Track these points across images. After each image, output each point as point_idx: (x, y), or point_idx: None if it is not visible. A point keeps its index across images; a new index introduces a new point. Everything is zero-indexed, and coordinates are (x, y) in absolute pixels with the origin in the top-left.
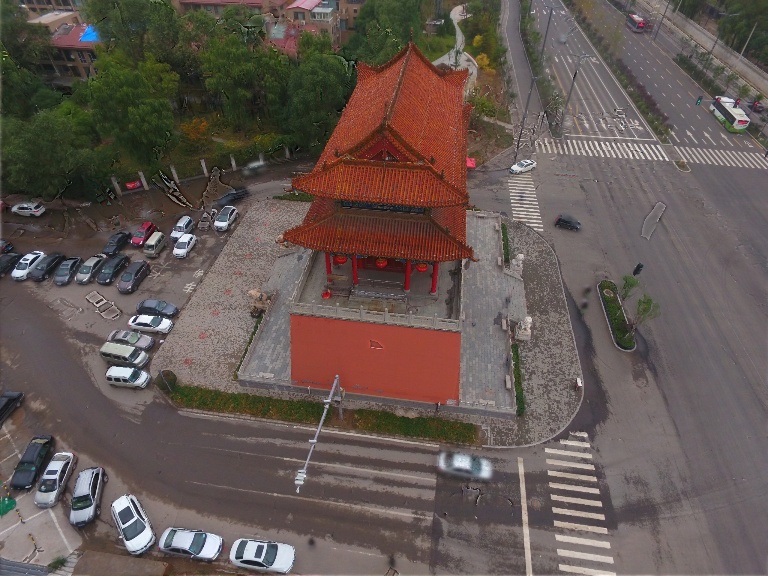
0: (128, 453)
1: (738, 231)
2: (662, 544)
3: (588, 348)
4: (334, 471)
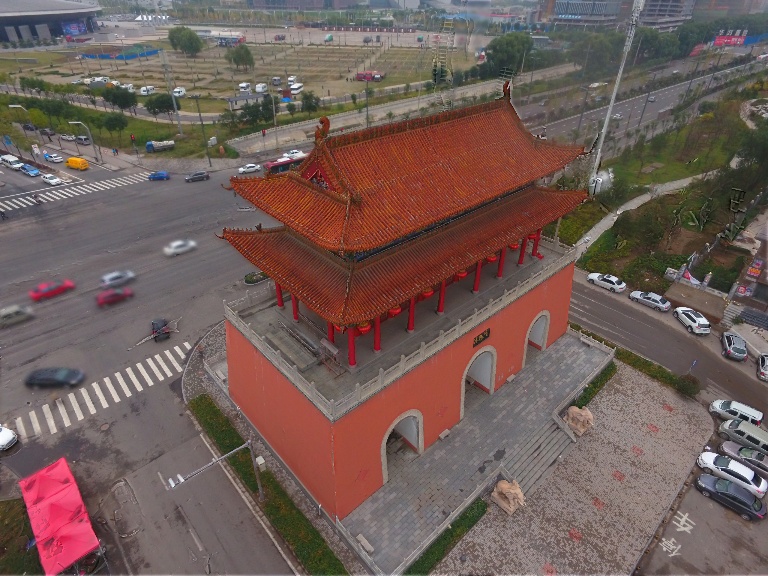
0: (711, 364)
1: (79, 258)
2: None
3: None
4: None
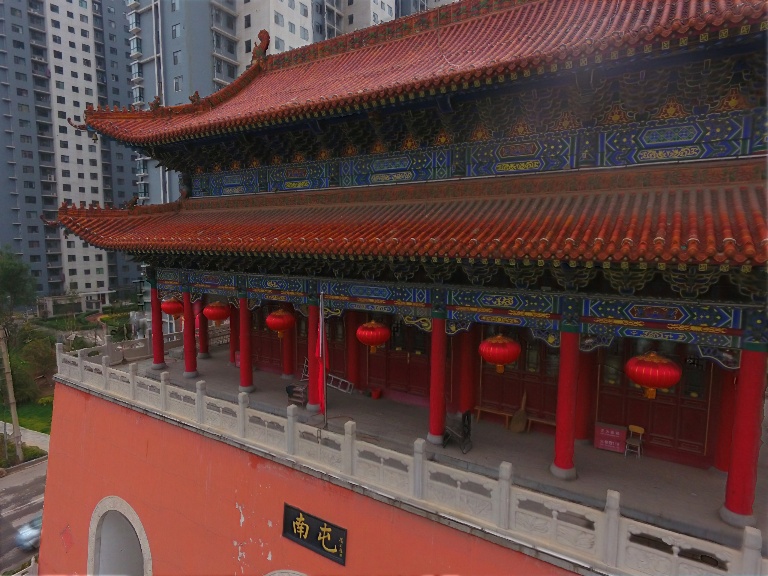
0: None
1: None
2: None
3: None
4: None
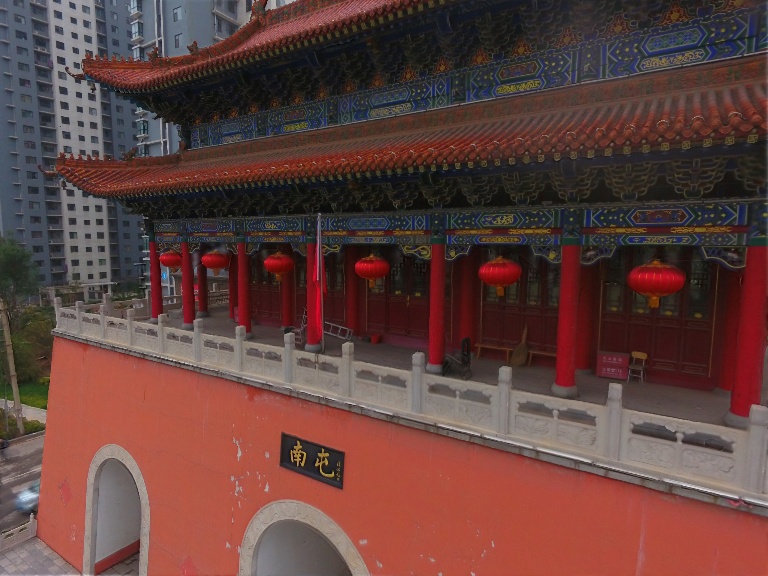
0: None
1: None
2: None
3: None
4: None
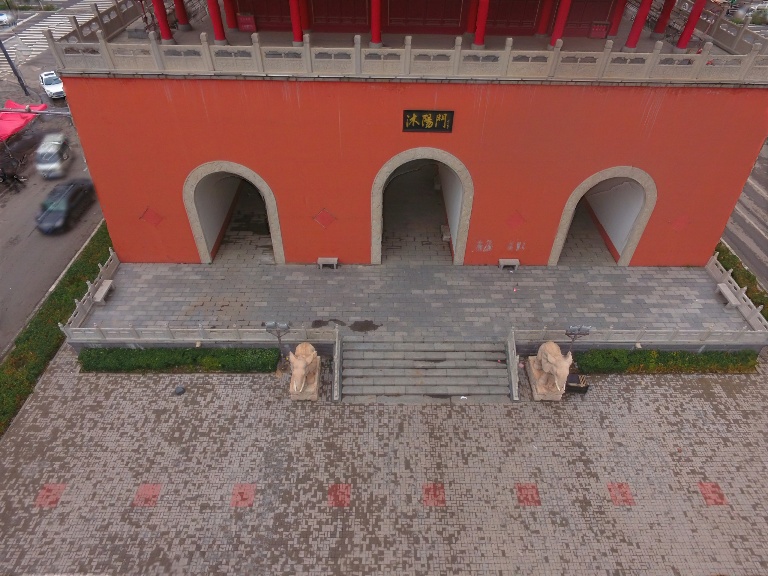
0: None
1: None
2: None
3: None
4: (760, 223)
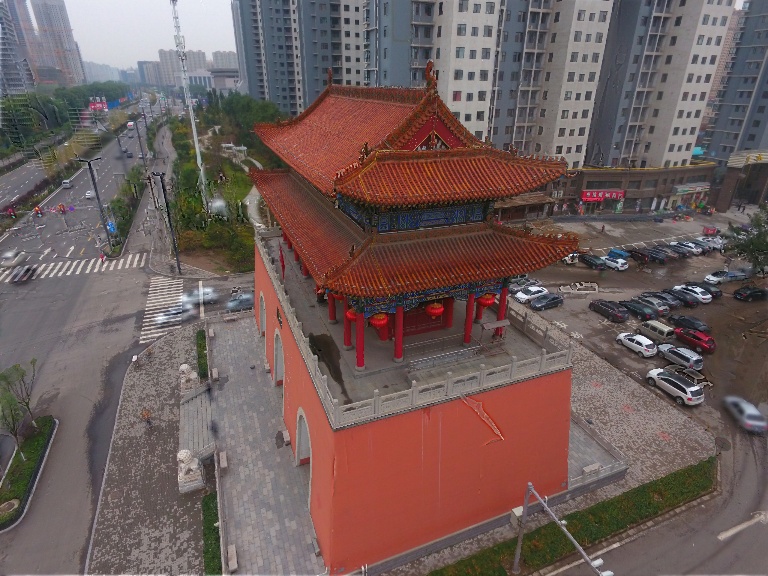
0: None
1: None
2: (109, 312)
3: (102, 408)
4: None
